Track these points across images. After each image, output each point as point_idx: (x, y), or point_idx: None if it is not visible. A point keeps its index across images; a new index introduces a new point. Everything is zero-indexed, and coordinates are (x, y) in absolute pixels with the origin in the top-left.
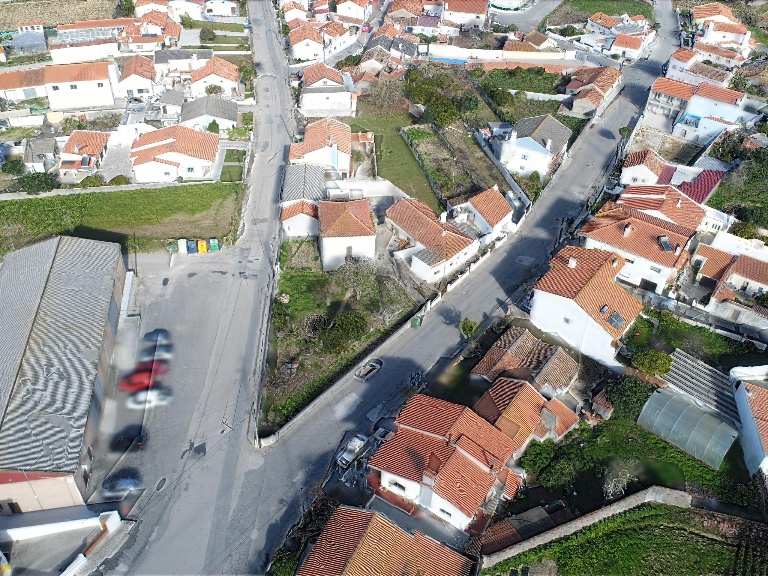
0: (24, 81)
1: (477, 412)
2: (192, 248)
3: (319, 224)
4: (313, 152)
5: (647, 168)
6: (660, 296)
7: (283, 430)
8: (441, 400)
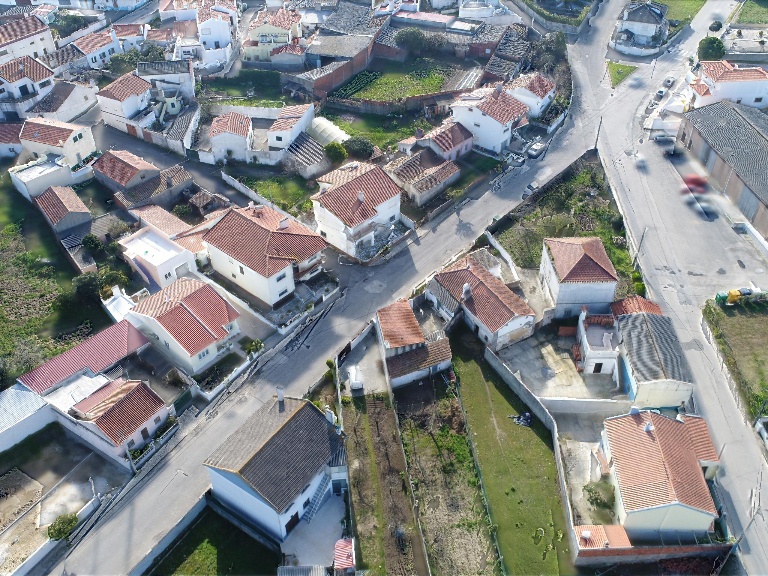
0: None
1: (464, 136)
2: None
3: None
4: (669, 417)
5: None
6: None
7: None
8: (491, 115)
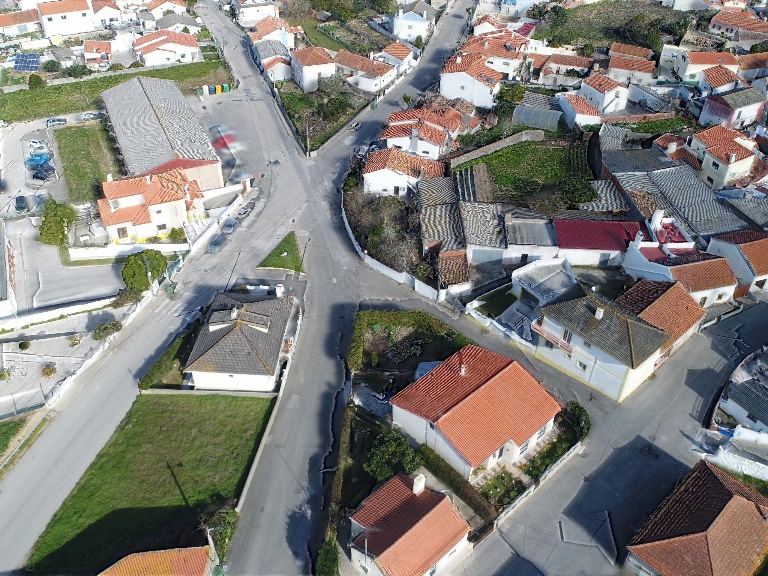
0: (16, 20)
1: None
2: (212, 90)
3: (292, 68)
4: (269, 35)
5: (489, 24)
6: (512, 81)
7: (320, 149)
8: (409, 110)
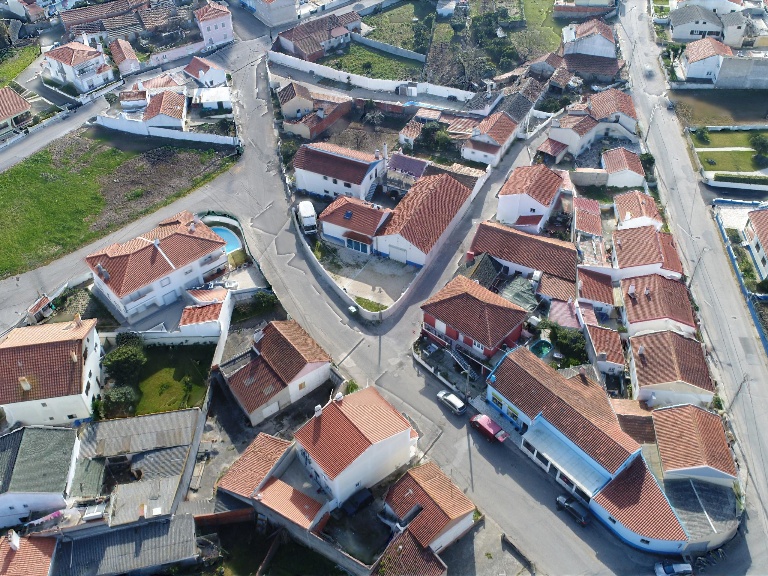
0: None
1: None
2: None
3: None
4: None
5: None
6: None
7: None
8: None
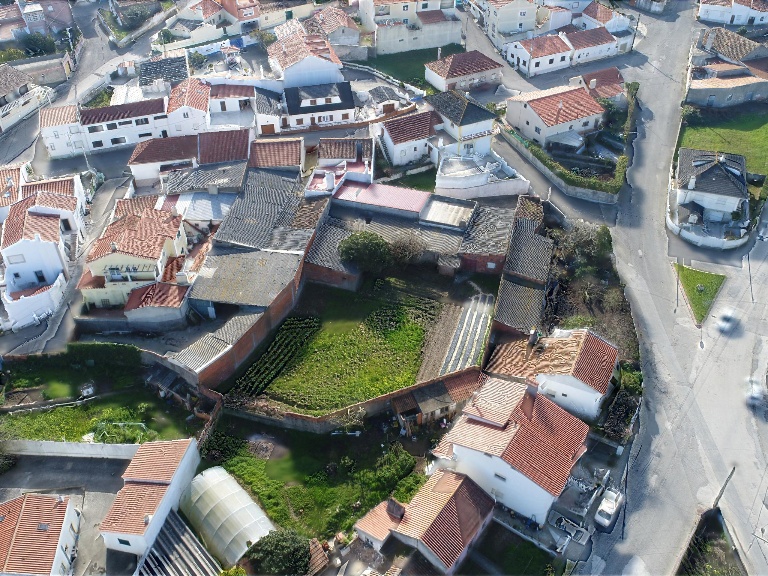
0: None
1: (480, 510)
2: None
3: None
4: None
5: None
6: None
7: None
8: (529, 475)
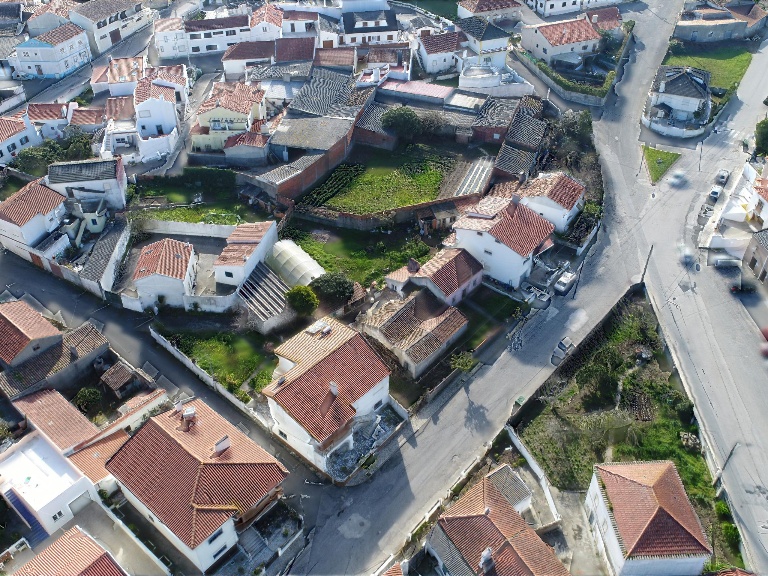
0: None
1: (472, 269)
2: None
3: None
4: None
5: None
6: None
7: None
8: (507, 243)
